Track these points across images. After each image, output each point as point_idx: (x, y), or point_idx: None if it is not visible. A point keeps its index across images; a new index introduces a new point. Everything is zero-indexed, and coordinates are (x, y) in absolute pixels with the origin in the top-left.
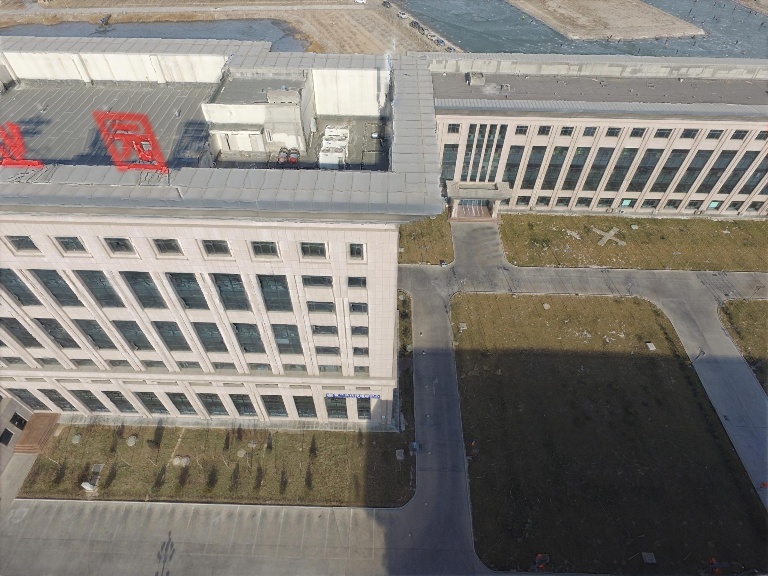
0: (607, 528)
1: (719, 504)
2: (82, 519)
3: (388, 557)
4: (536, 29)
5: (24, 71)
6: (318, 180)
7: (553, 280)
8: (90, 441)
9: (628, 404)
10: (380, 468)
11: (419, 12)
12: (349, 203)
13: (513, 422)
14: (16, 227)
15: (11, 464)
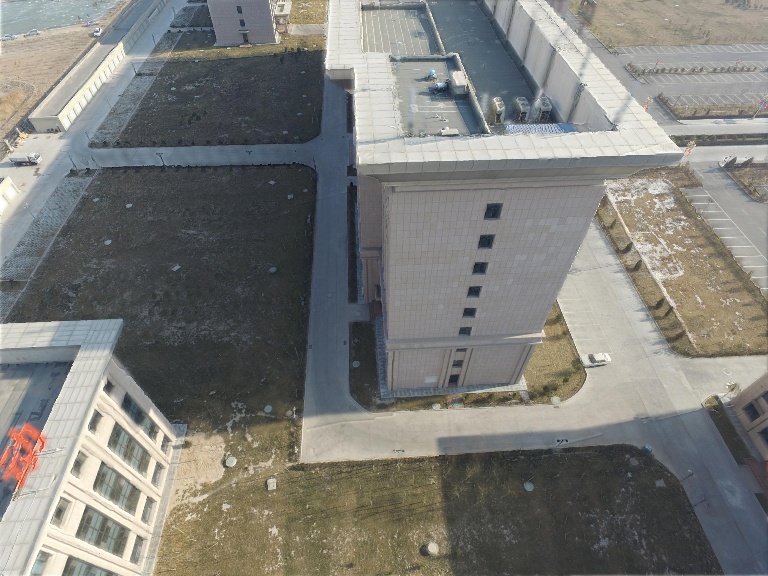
0: None
1: None
2: None
3: None
4: (7, 6)
5: None
6: None
7: None
8: None
9: None
10: None
11: None
12: None
13: None
14: None
15: None
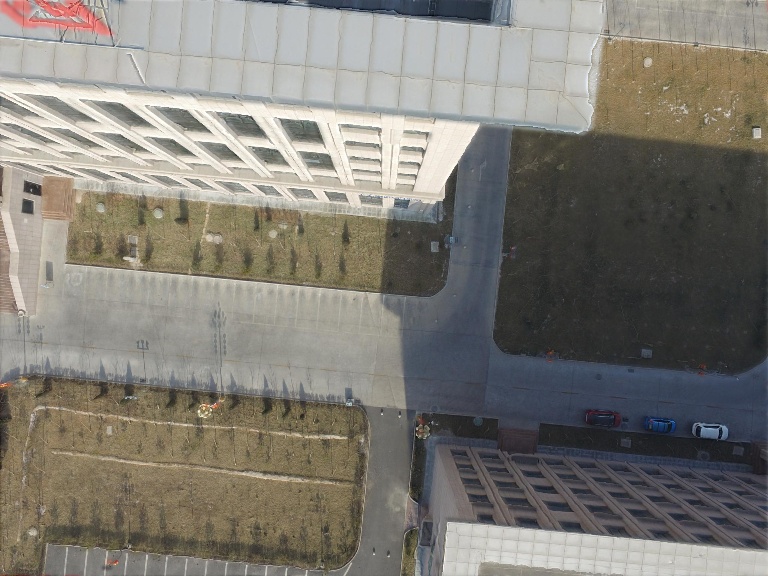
0: (619, 328)
1: (735, 315)
2: (135, 286)
3: (415, 337)
4: None
5: None
6: (374, 43)
7: (672, 16)
8: (115, 211)
9: (694, 207)
10: (413, 259)
11: None
12: (428, 111)
13: (560, 219)
14: None
15: (46, 230)
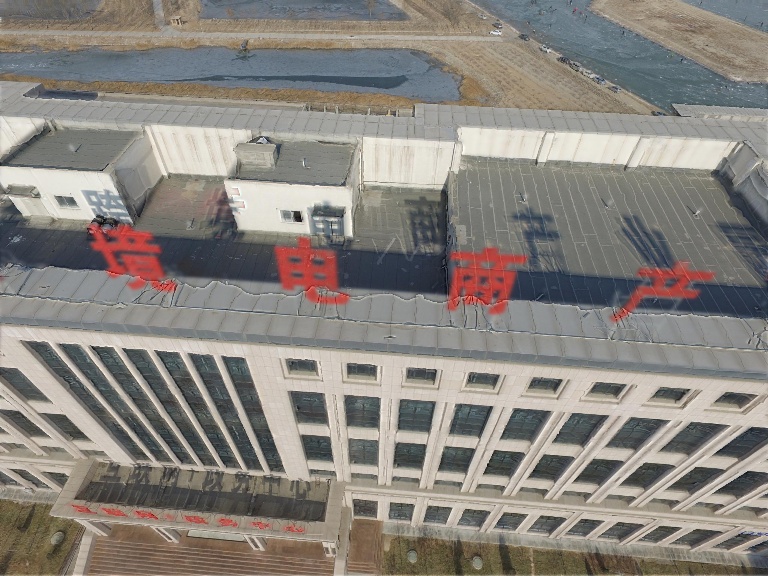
0: None
1: None
2: None
3: None
4: (690, 68)
5: (469, 147)
6: None
7: None
8: (429, 560)
9: None
10: None
11: (559, 46)
12: None
13: None
14: (632, 377)
15: None
